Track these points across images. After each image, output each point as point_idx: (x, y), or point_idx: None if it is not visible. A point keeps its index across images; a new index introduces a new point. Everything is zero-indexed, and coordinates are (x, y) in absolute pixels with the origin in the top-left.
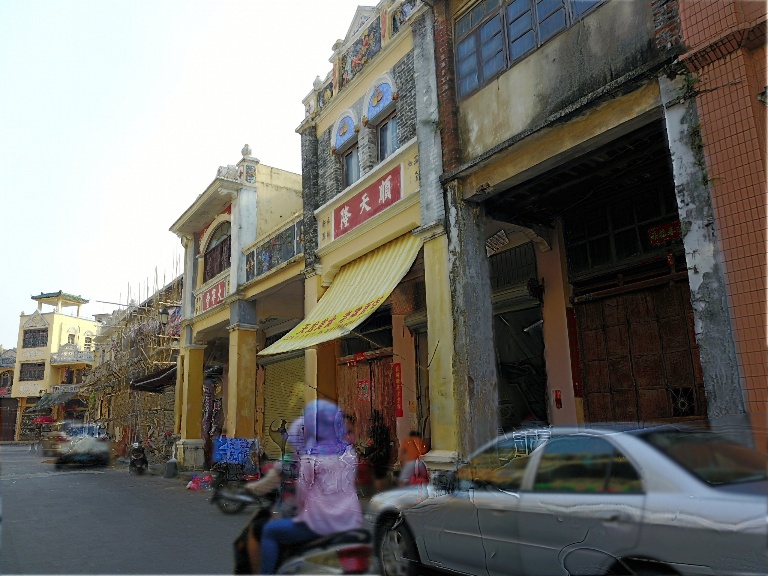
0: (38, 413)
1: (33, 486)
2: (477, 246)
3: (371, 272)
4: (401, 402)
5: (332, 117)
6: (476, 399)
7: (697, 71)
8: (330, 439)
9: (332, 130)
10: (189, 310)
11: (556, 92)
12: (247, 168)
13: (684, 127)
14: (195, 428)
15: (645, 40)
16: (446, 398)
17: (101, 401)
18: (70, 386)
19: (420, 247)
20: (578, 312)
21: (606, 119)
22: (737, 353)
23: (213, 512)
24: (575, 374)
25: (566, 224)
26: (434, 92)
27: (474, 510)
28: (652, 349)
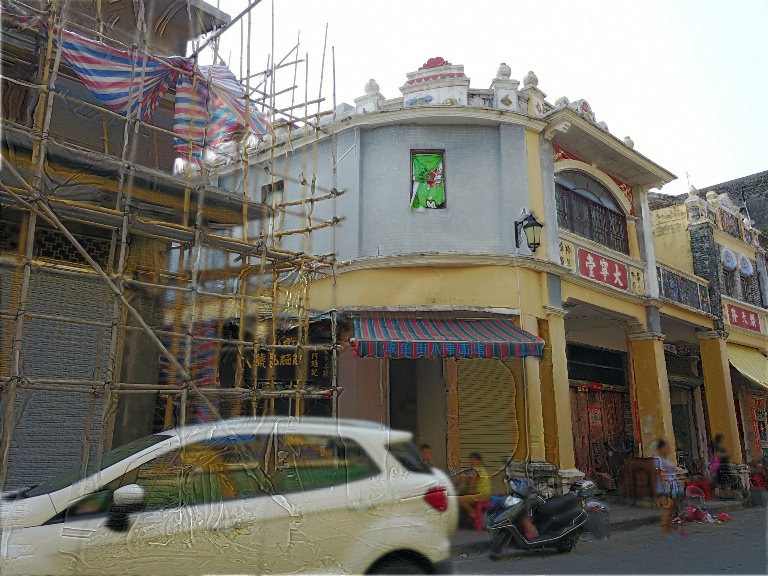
0: None
1: None
2: None
3: None
4: None
5: (720, 240)
6: None
7: None
8: None
9: (723, 250)
10: (557, 253)
11: None
12: None
13: None
14: None
15: None
16: None
17: None
18: None
19: None
20: None
21: None
22: None
23: None
24: None
25: None
26: None
27: None
28: None
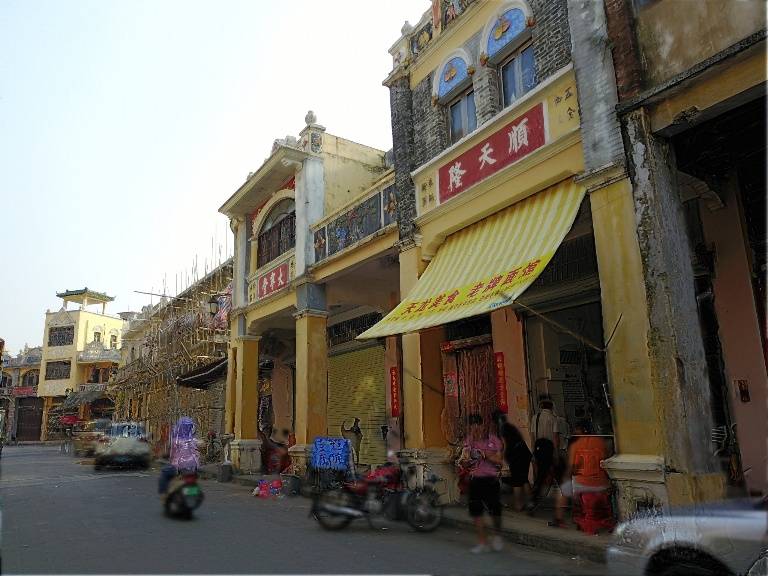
0: (64, 412)
1: (79, 491)
2: (671, 192)
3: (499, 237)
4: (505, 397)
5: (433, 62)
6: (688, 388)
7: None
8: (438, 440)
9: (434, 76)
10: (242, 298)
11: None
12: (312, 136)
13: None
14: (251, 427)
15: None
16: (639, 387)
17: (130, 400)
18: (96, 385)
19: (580, 199)
20: (765, 283)
21: None
22: None
23: (310, 527)
24: (767, 359)
25: (744, 175)
26: (599, 4)
27: None
28: None
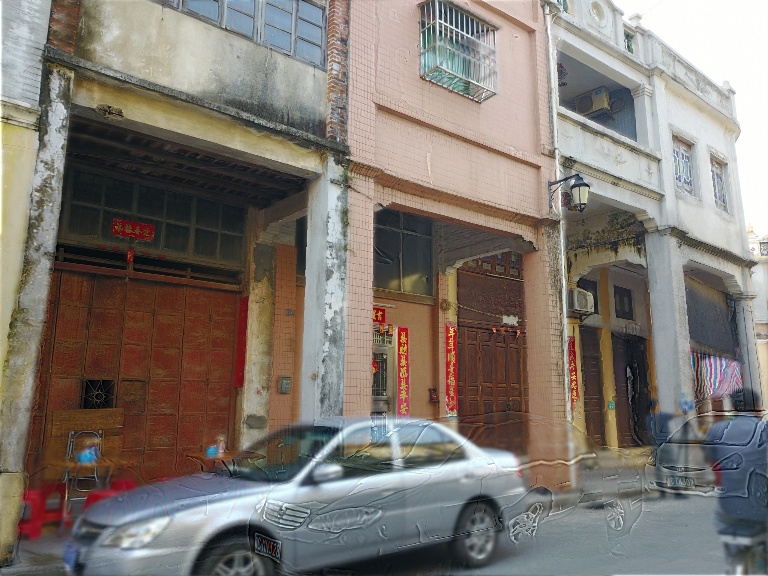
0: None
1: None
2: None
3: None
4: None
5: None
6: None
7: (351, 172)
8: None
9: None
10: None
11: (236, 88)
12: None
13: (339, 203)
14: None
15: (317, 117)
16: None
17: None
18: None
19: None
20: None
21: (278, 151)
22: (346, 370)
23: None
24: None
25: None
26: None
27: (470, 482)
28: (76, 336)
